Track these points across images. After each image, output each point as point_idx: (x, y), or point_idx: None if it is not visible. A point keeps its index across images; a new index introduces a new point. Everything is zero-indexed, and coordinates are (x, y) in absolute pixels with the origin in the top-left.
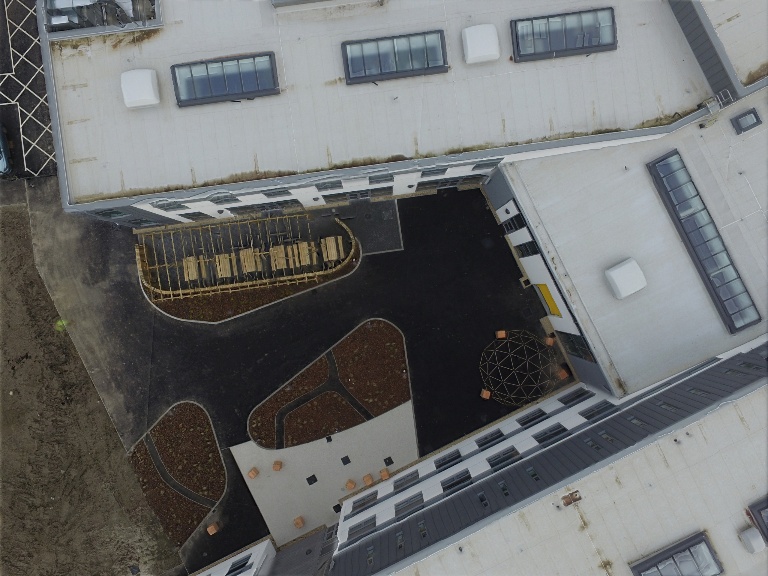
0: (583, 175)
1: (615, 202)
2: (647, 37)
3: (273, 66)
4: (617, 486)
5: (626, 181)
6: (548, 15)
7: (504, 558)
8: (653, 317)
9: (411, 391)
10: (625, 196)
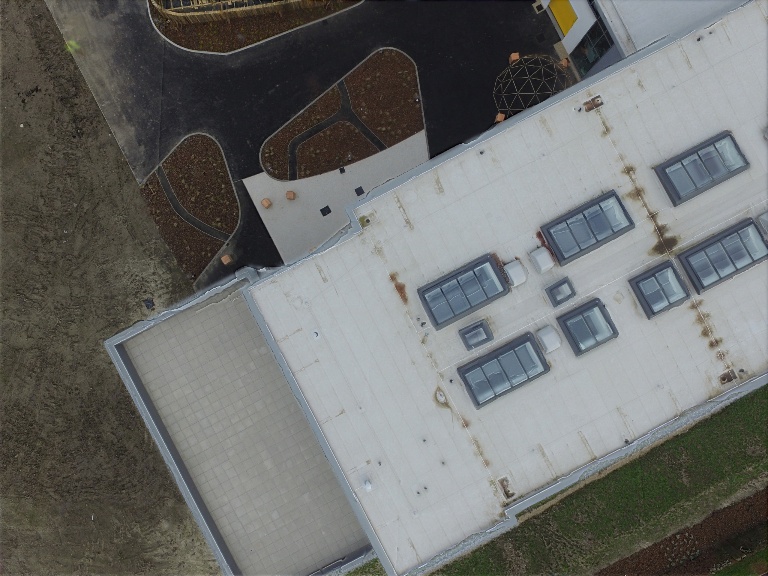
0: None
1: None
2: None
3: None
4: (640, 90)
5: None
6: None
7: (526, 162)
8: None
9: (424, 121)
10: None
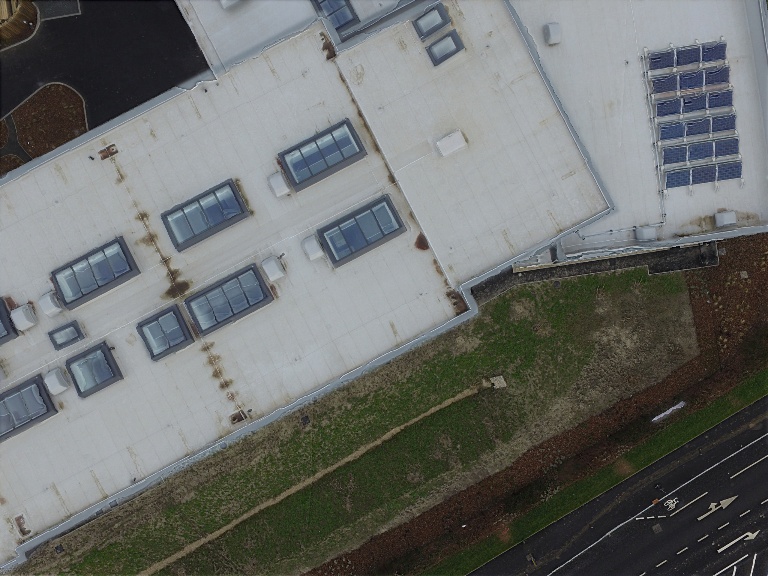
0: None
1: None
2: None
3: None
4: (152, 139)
5: None
6: None
7: (38, 209)
8: (263, 29)
9: None
10: None
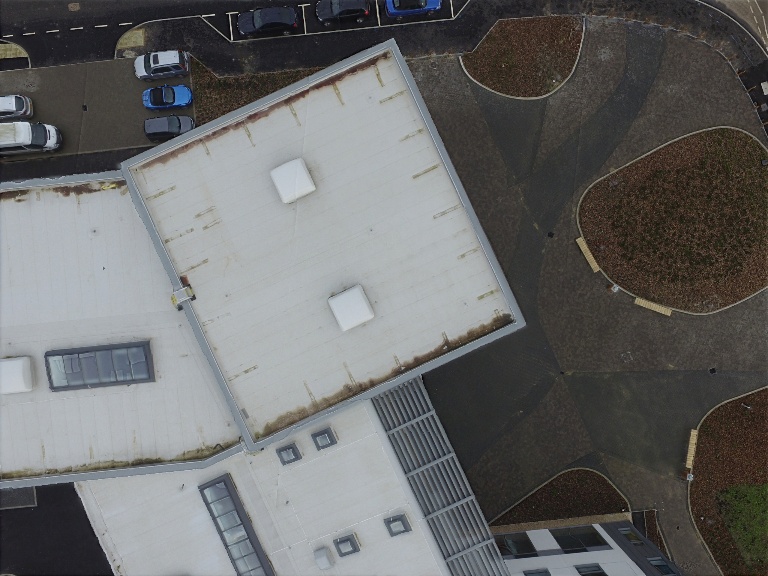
0: (144, 488)
1: (174, 518)
2: (189, 369)
3: None
4: None
5: (184, 498)
6: (86, 346)
7: None
8: None
9: None
10: (183, 513)
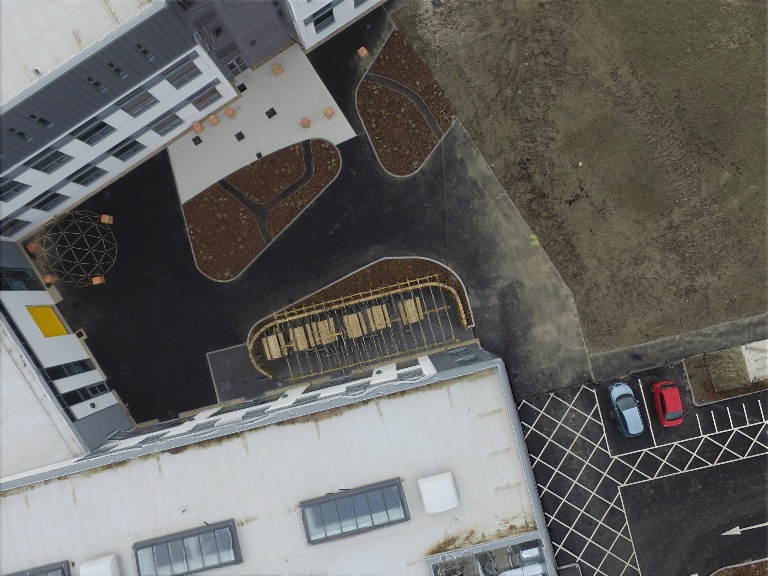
0: (1, 453)
1: None
2: None
3: (307, 530)
4: None
5: None
6: None
7: None
8: None
9: (183, 213)
10: None
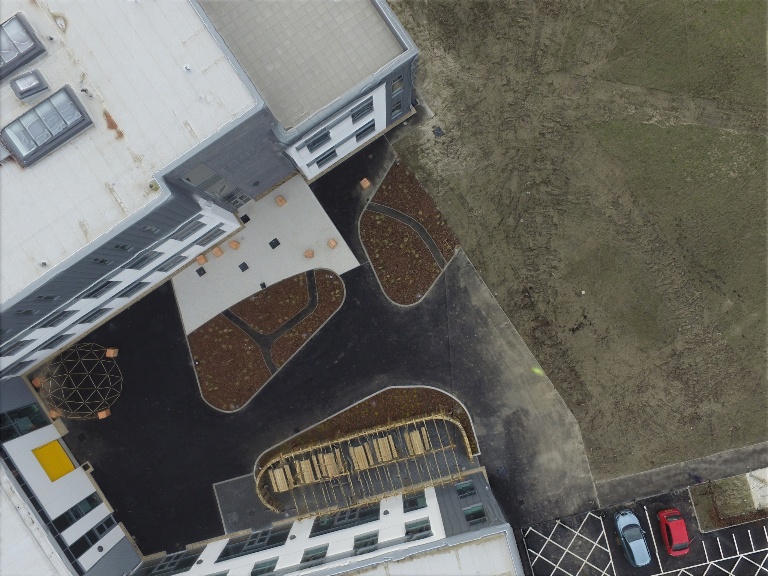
0: None
1: None
2: None
3: None
4: None
5: None
6: None
7: (1, 260)
8: None
9: (188, 344)
10: None
